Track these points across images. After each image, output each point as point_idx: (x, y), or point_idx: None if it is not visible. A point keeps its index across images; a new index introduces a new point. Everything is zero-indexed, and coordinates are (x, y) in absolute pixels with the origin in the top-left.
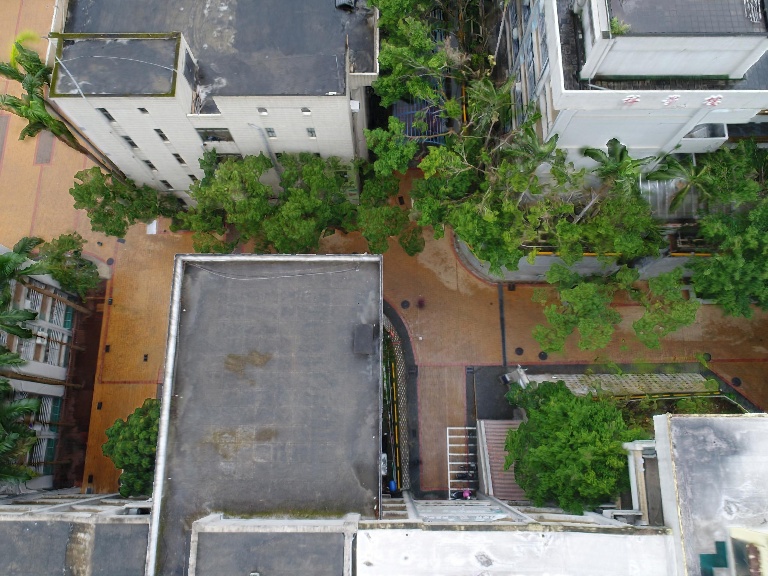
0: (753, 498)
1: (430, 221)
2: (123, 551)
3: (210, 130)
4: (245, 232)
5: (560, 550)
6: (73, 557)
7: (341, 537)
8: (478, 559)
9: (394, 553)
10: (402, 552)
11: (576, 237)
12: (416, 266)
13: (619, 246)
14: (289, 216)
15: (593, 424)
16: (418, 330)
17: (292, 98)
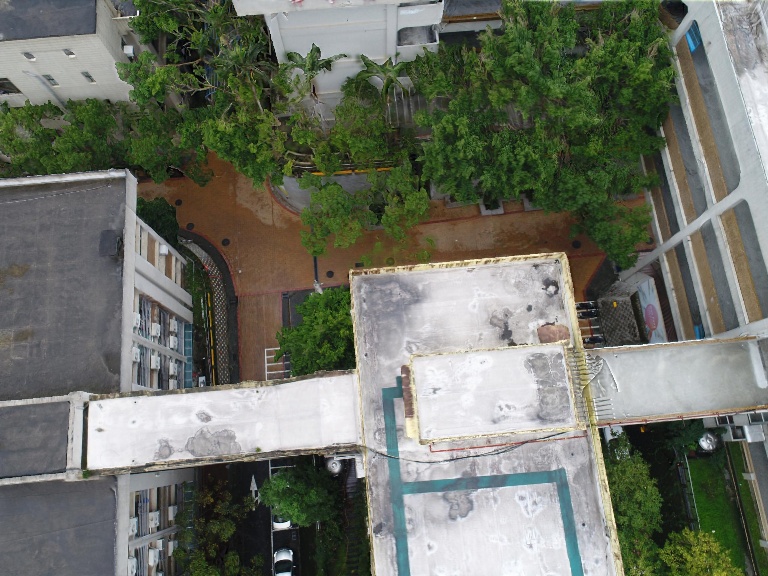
0: (431, 337)
1: (188, 143)
2: None
3: None
4: (36, 174)
5: (272, 402)
6: None
7: (68, 406)
8: (199, 417)
9: (123, 419)
10: (130, 417)
11: (321, 146)
12: (235, 207)
13: (354, 148)
14: (59, 149)
15: (339, 308)
16: (238, 264)
17: (48, 40)
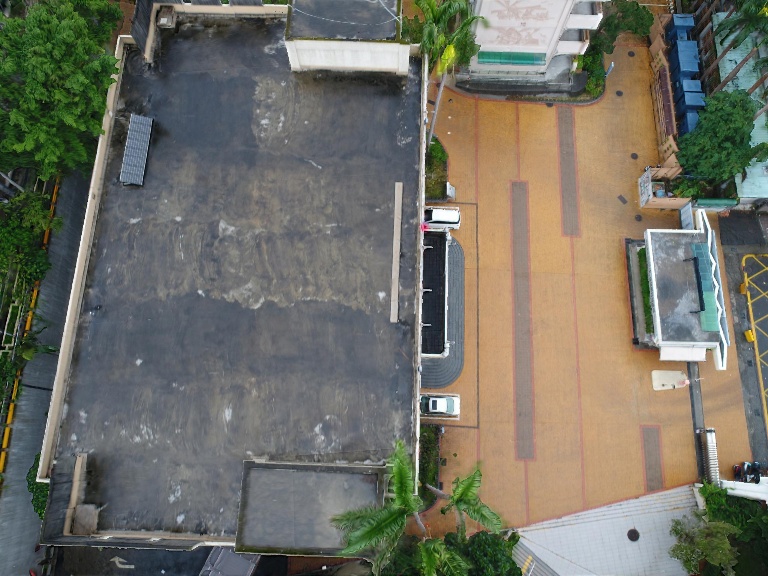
0: None
1: None
2: None
3: None
4: None
5: None
6: None
7: None
8: None
9: None
10: None
11: None
12: None
13: None
14: None
15: None
16: None
17: None
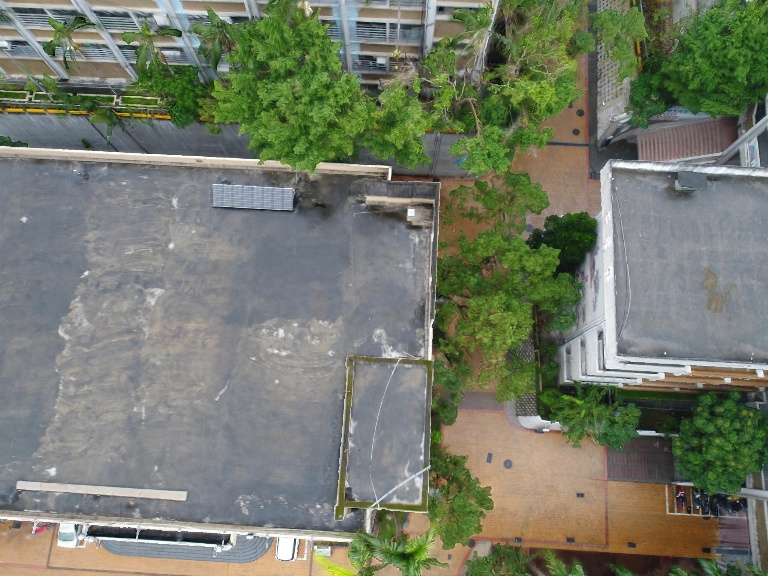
0: None
1: None
2: None
3: None
4: None
5: None
6: None
7: None
8: None
9: None
10: None
11: None
12: None
13: None
14: (540, 264)
15: None
16: None
17: None
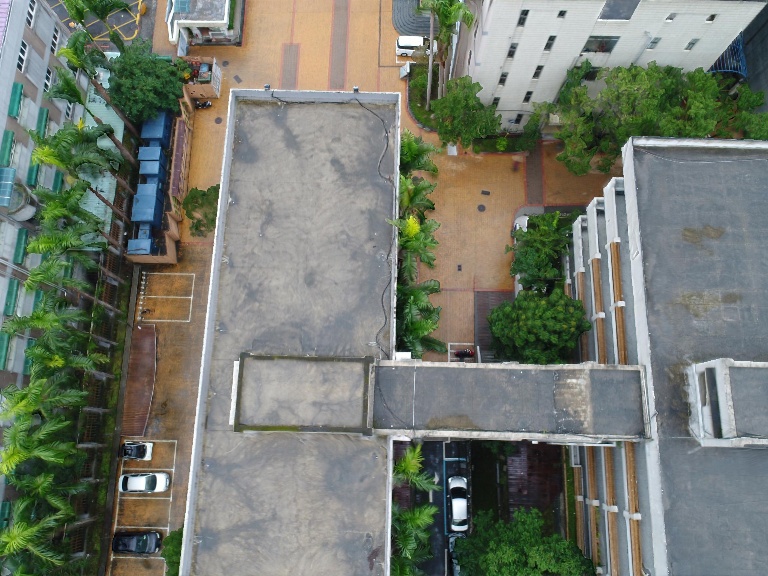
0: None
1: None
2: (619, 394)
3: (600, 39)
4: (624, 135)
5: None
6: (566, 400)
7: None
8: None
9: None
10: None
11: None
12: None
13: None
14: (697, 114)
15: None
16: None
17: (714, 3)
